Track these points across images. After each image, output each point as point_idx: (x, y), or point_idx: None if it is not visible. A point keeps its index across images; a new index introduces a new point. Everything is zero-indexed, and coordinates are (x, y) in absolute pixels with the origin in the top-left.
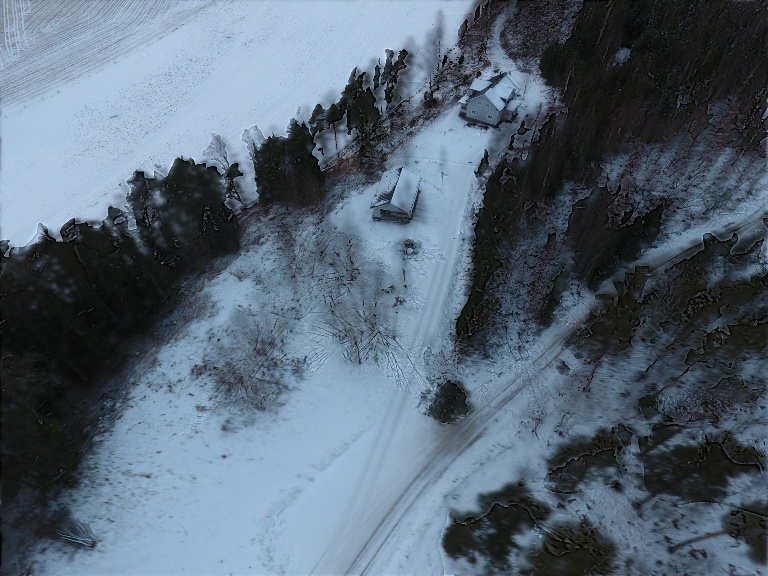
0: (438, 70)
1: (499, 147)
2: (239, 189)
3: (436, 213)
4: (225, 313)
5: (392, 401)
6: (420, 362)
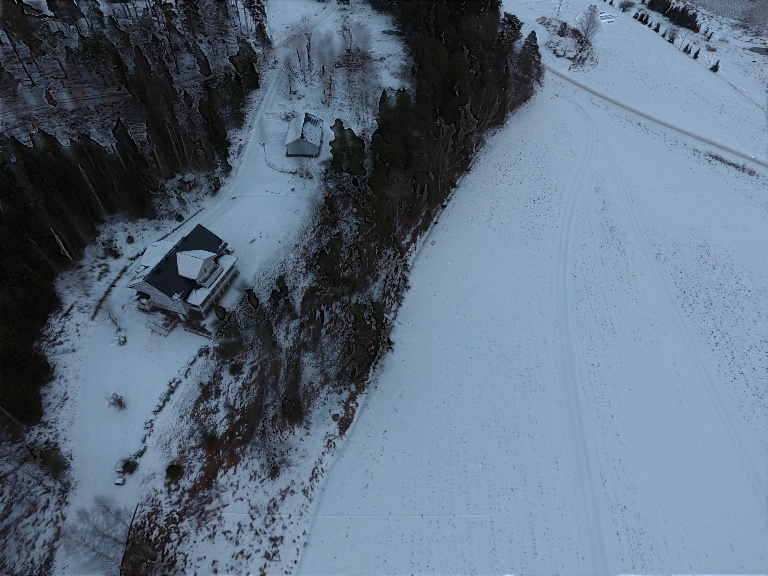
0: (270, 459)
1: (194, 222)
2: (479, 208)
3: (271, 141)
4: (387, 74)
5: (291, 60)
6: (279, 72)
